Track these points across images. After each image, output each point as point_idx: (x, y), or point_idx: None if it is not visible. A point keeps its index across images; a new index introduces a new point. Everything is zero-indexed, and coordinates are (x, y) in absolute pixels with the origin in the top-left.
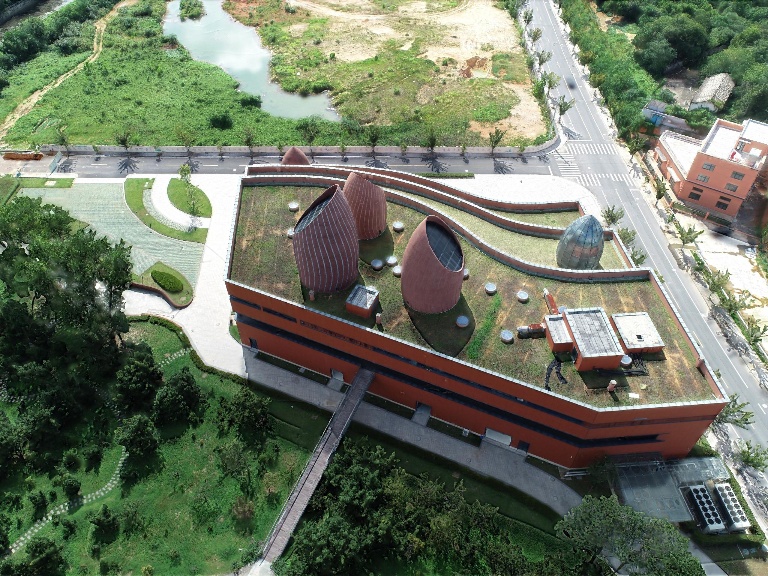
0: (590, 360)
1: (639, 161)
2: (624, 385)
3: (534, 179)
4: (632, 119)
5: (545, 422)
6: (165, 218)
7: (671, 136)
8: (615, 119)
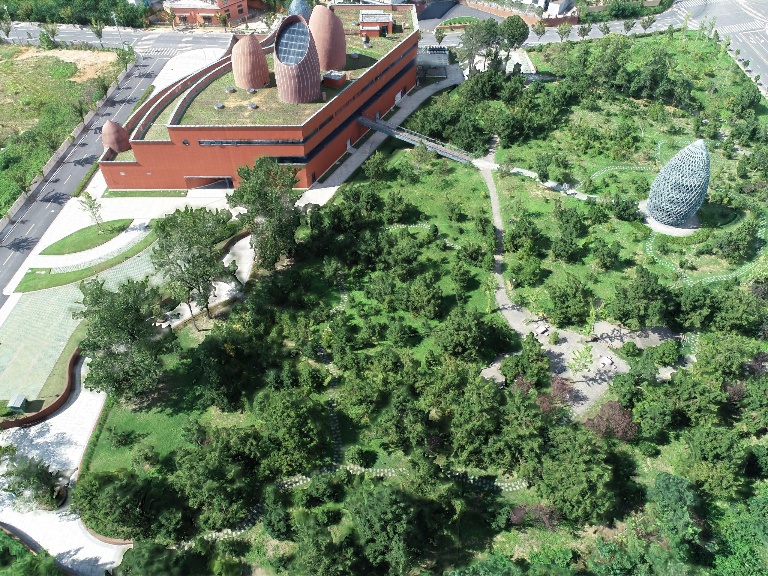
0: (392, 23)
1: (175, 28)
2: None
3: (172, 65)
4: (135, 12)
5: (408, 61)
6: (118, 249)
7: (169, 3)
8: (119, 24)
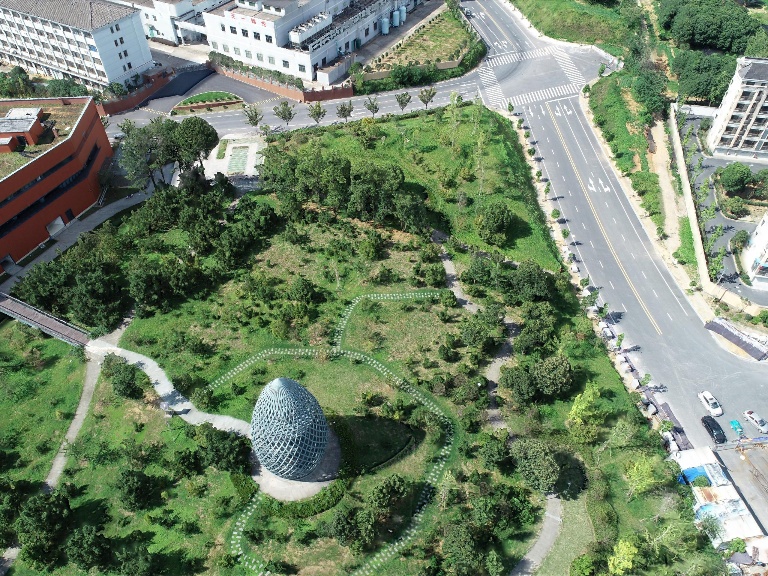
0: (32, 131)
1: None
2: (58, 130)
3: None
4: None
5: (61, 180)
6: None
7: None
8: None
